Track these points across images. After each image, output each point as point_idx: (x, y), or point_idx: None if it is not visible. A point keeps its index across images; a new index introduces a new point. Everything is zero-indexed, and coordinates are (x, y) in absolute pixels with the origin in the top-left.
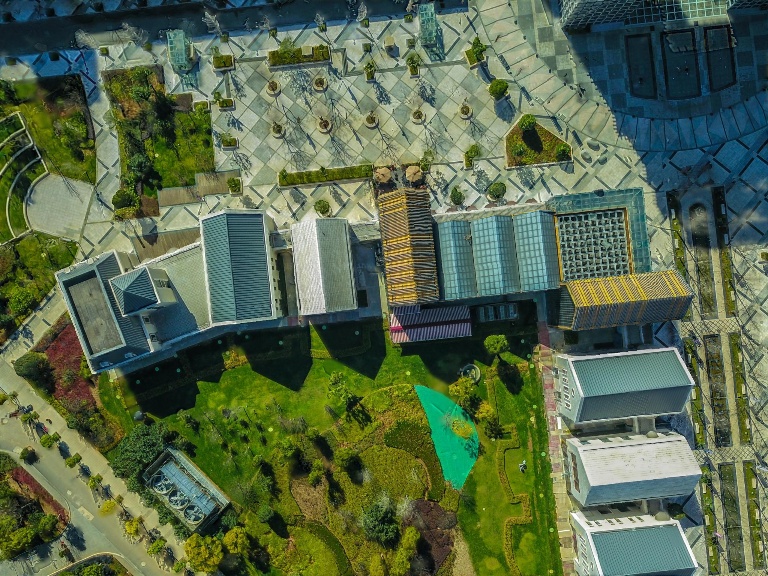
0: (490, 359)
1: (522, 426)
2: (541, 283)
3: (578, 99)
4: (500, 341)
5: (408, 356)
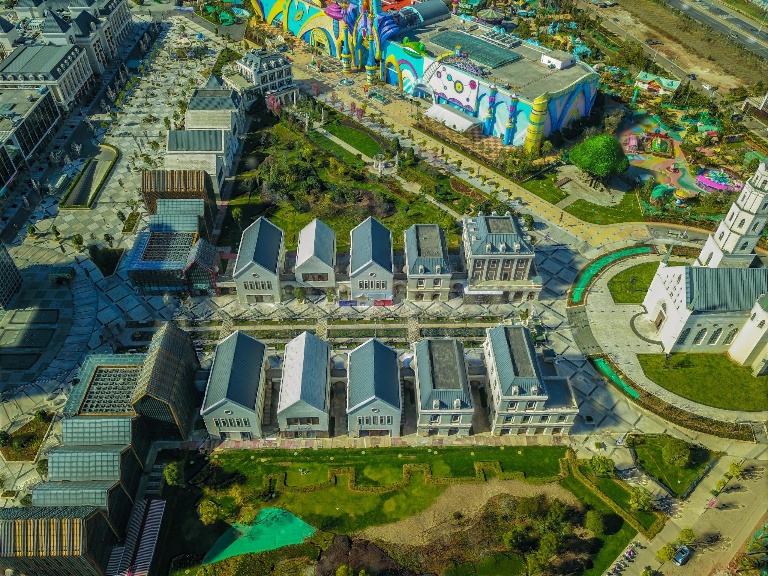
0: (199, 492)
1: (267, 469)
2: (124, 424)
3: (9, 404)
4: (168, 467)
5: (170, 570)
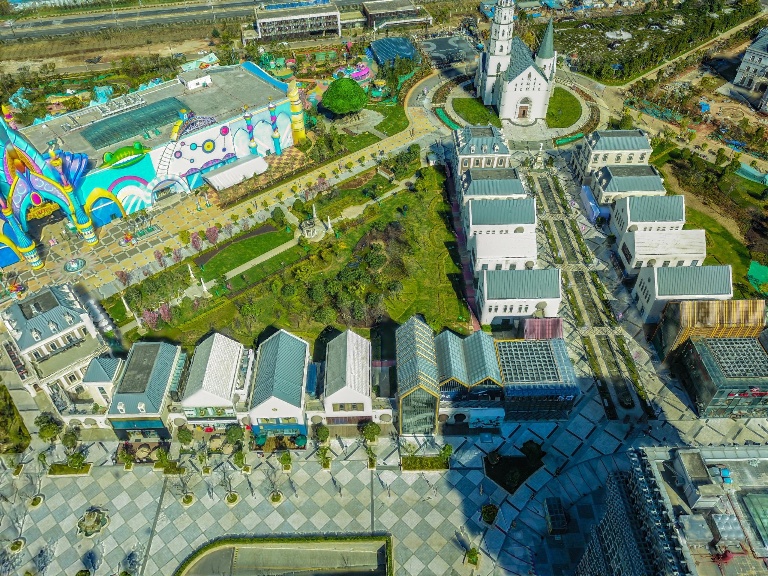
0: None
1: None
2: None
3: None
4: None
5: None
